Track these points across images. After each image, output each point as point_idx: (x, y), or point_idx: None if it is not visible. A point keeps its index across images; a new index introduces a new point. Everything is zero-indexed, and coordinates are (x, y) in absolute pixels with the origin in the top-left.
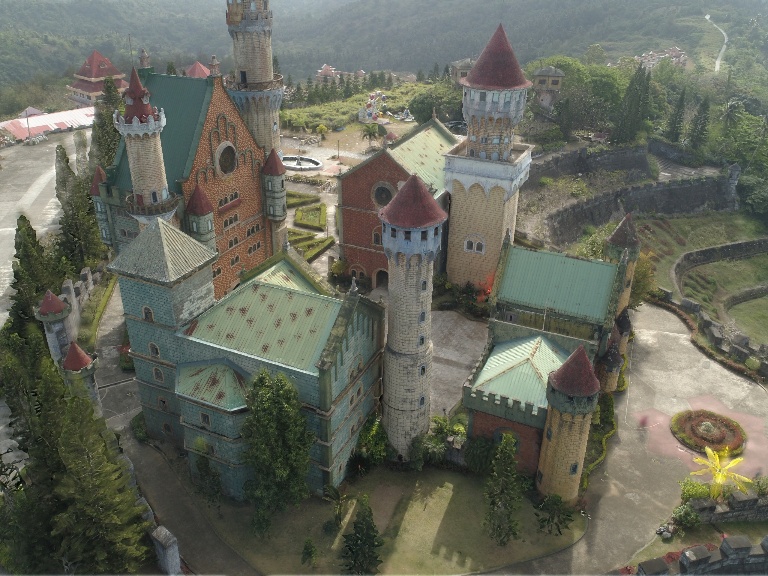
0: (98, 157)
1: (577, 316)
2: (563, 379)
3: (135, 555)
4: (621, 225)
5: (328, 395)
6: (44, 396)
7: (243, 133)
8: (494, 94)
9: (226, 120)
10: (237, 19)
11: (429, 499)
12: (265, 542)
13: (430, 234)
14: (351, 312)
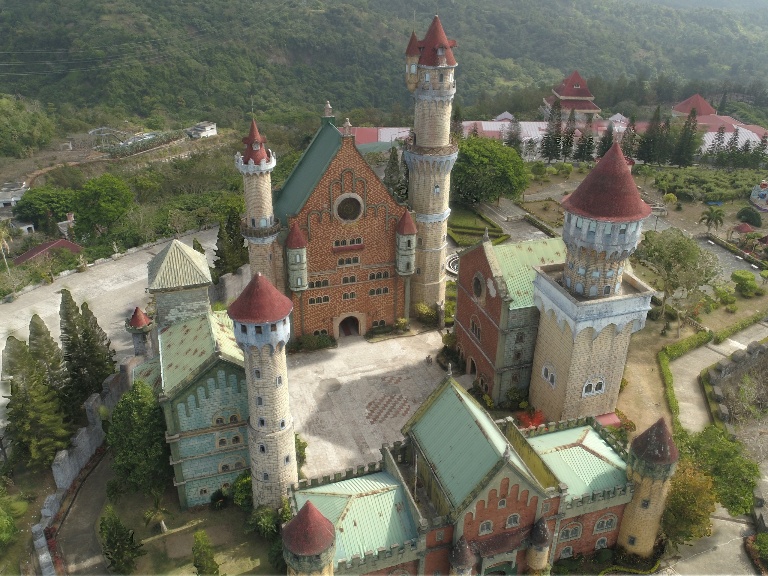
0: (389, 174)
1: (445, 488)
2: None
3: (33, 457)
4: None
5: (169, 423)
6: (32, 330)
7: (378, 189)
8: (578, 218)
9: (354, 175)
10: (410, 87)
11: (232, 560)
12: (123, 507)
13: (250, 330)
14: (205, 367)
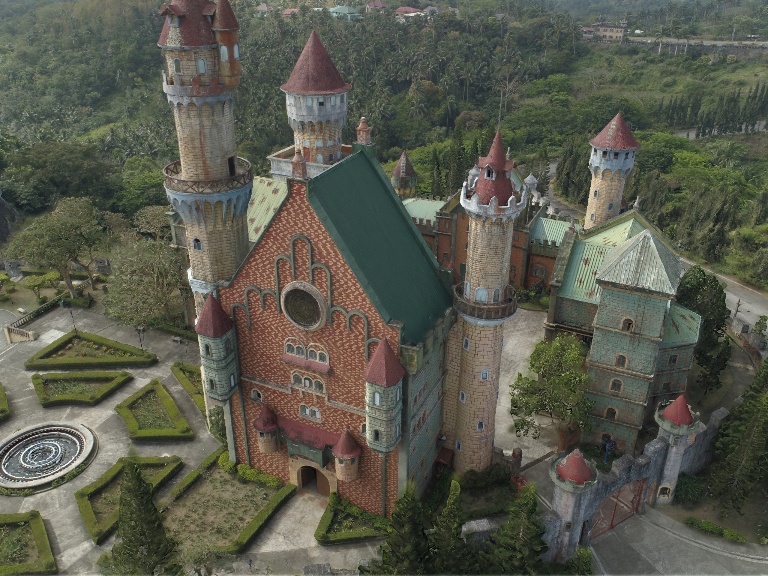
0: None
1: None
2: (622, 202)
3: None
4: (406, 161)
5: None
6: None
7: None
8: None
9: None
10: None
11: None
12: None
13: None
14: None
